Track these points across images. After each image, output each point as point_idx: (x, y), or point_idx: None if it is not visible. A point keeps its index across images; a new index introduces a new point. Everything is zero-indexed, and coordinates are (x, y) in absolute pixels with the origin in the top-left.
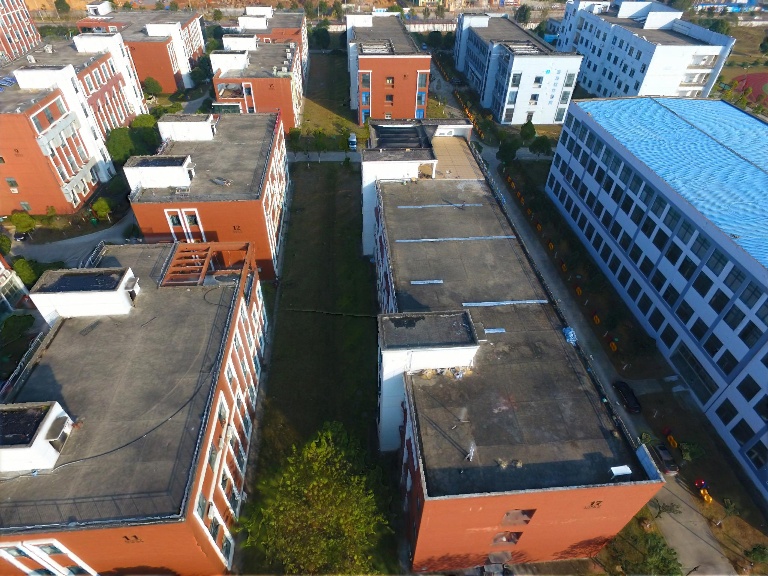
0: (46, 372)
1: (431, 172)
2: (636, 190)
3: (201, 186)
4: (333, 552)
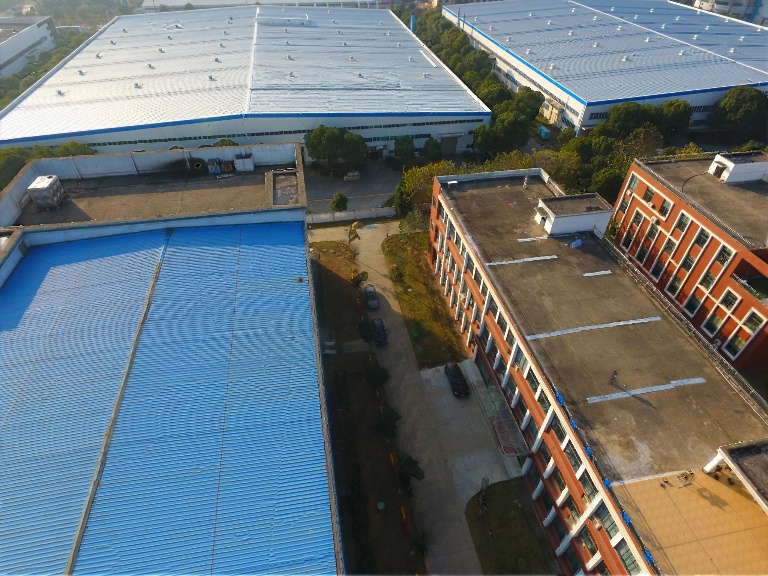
0: None
1: (726, 498)
2: None
3: None
4: None
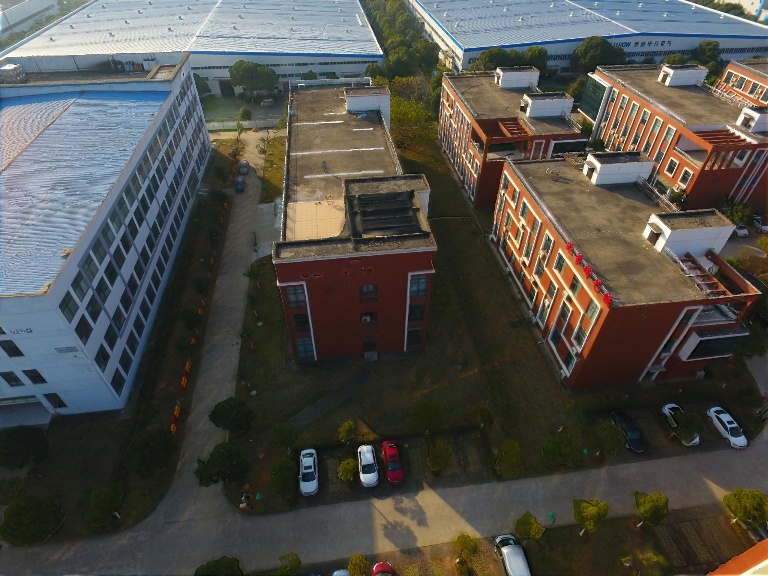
0: None
1: None
2: (138, 187)
3: (573, 174)
4: (399, 107)
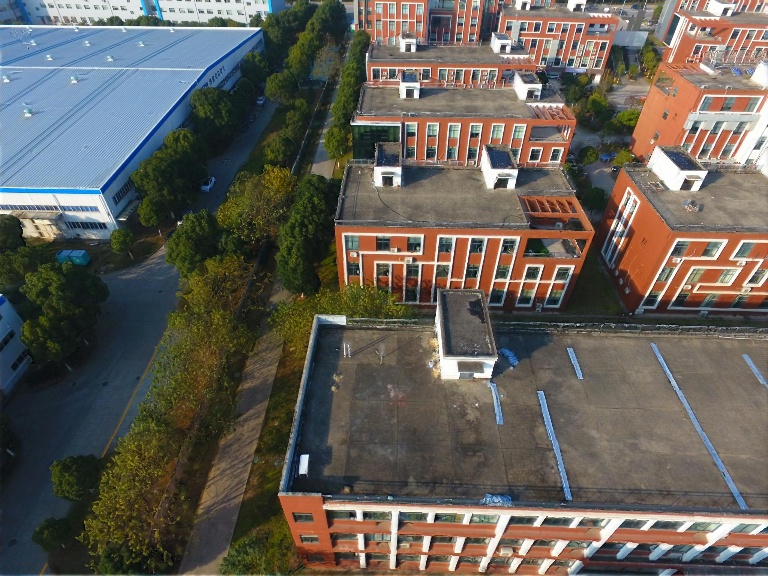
0: (437, 173)
1: None
2: None
3: (677, 197)
4: None
